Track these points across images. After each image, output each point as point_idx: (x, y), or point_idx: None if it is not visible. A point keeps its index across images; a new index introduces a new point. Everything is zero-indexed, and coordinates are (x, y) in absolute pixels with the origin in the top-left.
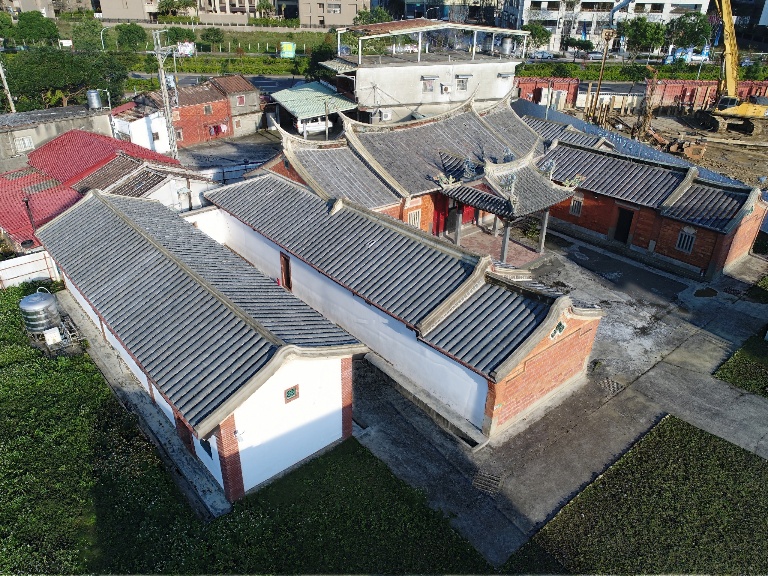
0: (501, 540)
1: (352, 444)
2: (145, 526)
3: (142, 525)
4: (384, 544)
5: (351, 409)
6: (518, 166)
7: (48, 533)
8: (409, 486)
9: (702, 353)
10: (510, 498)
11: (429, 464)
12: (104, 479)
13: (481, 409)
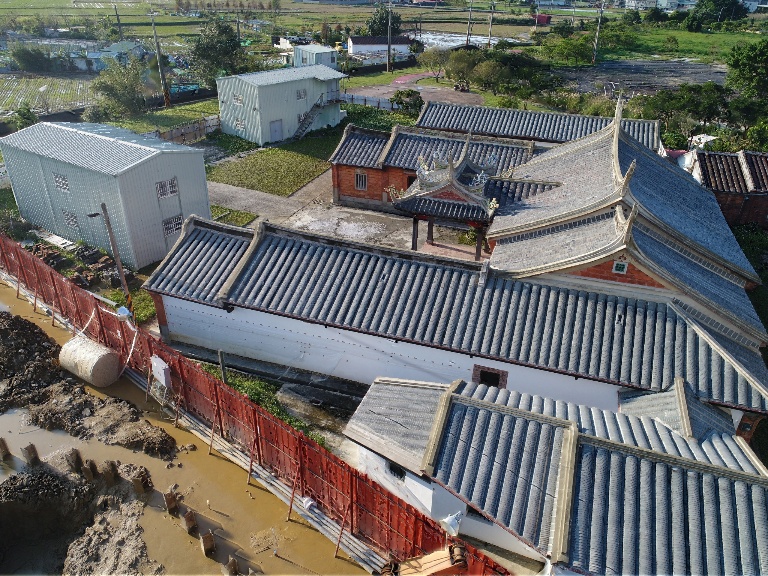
0: None
1: None
2: None
3: None
4: None
5: None
6: None
7: None
8: None
9: None
10: None
11: None
12: None
13: None
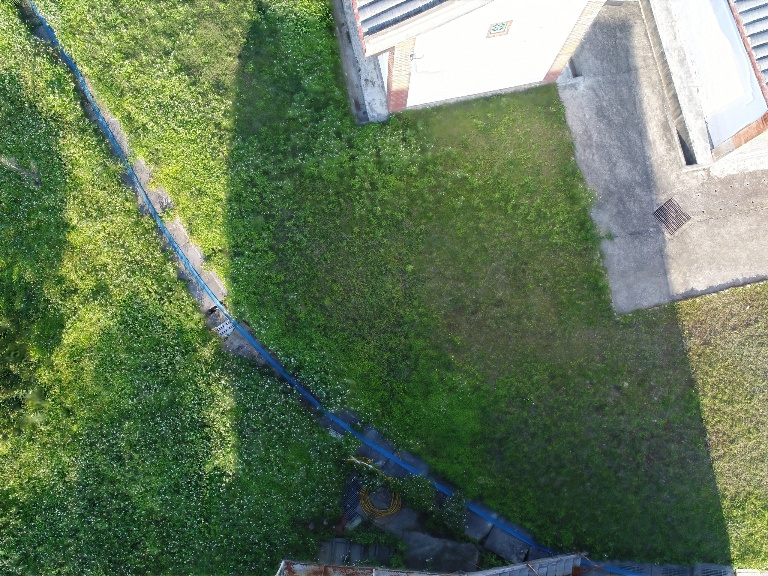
0: (641, 288)
1: (549, 95)
2: (297, 103)
3: (295, 98)
4: (521, 235)
5: (569, 57)
6: None
7: (206, 68)
8: (583, 184)
9: None
10: (684, 247)
11: (622, 162)
12: (269, 18)
13: (732, 128)
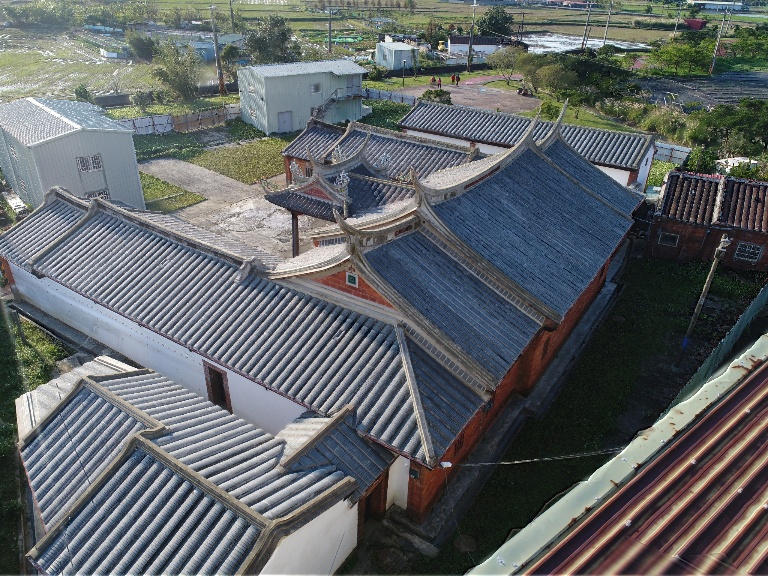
0: None
1: None
2: None
3: None
4: None
5: None
6: (331, 172)
7: None
8: None
9: (202, 208)
10: None
11: None
12: None
13: None
